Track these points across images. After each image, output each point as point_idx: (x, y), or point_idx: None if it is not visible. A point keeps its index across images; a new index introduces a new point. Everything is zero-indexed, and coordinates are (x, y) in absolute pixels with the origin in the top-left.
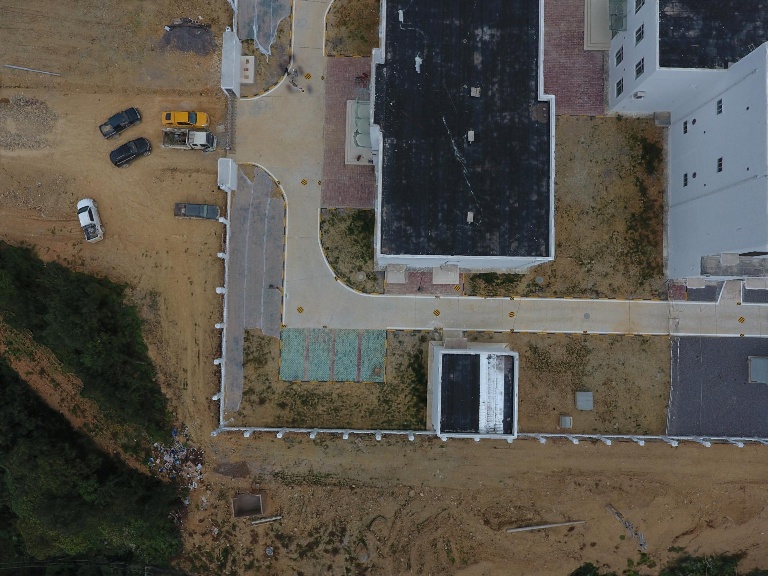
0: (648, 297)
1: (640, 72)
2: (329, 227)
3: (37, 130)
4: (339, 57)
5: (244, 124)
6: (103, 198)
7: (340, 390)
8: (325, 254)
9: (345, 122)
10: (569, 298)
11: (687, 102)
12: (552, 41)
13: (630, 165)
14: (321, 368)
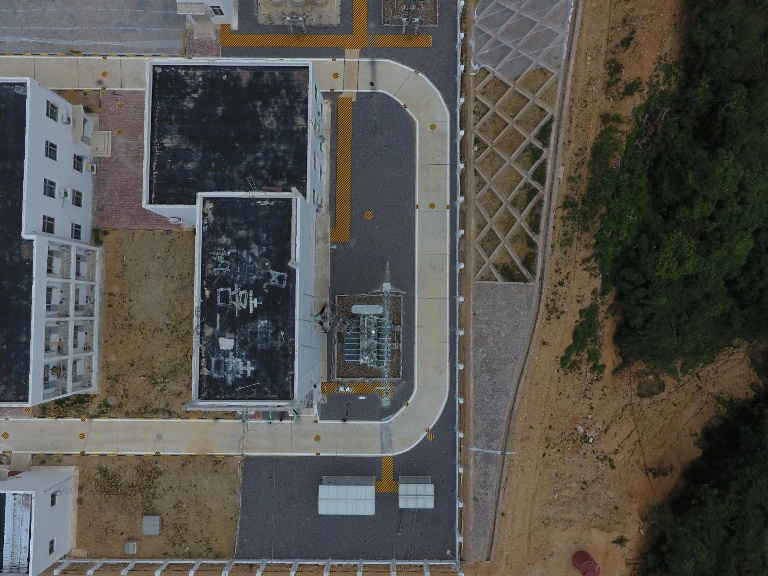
0: (222, 416)
1: None
2: None
3: None
4: None
5: None
6: None
7: None
8: None
9: None
10: (141, 418)
11: None
12: (129, 153)
13: None
14: None
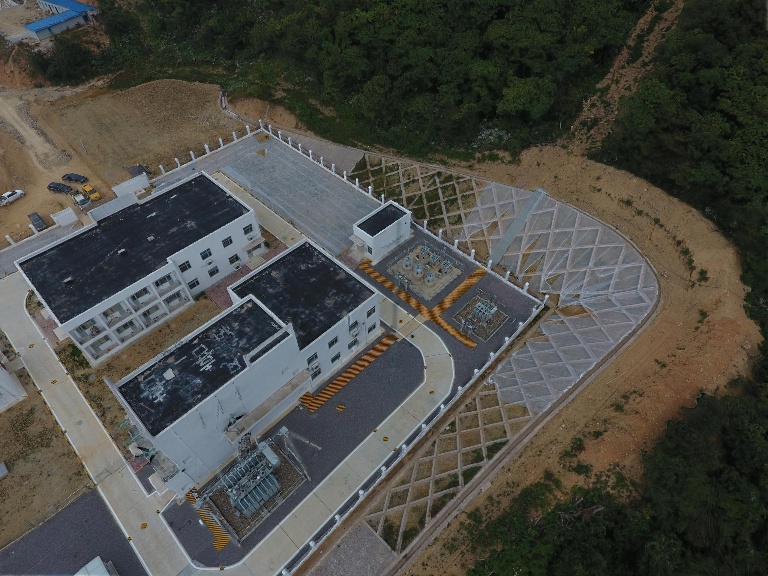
0: (121, 446)
1: None
2: None
3: (55, 164)
4: None
5: None
6: (29, 196)
7: None
8: None
9: None
10: (88, 402)
11: None
12: None
13: None
14: None
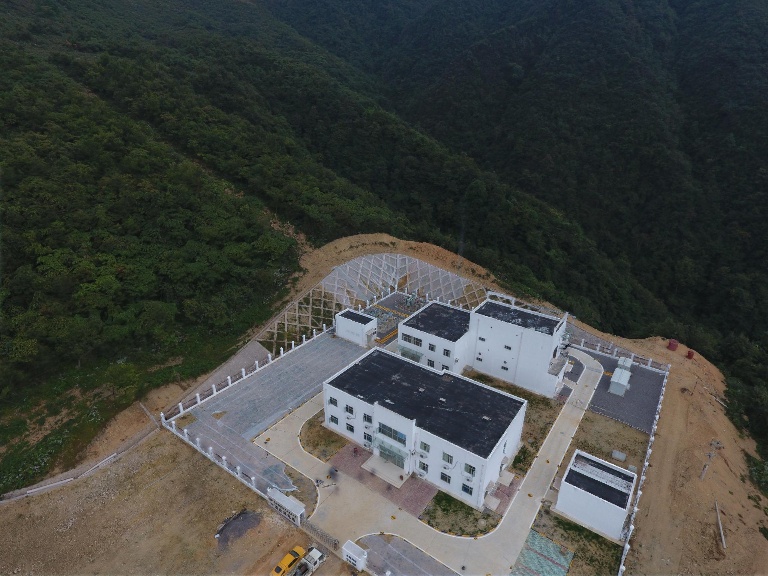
0: (560, 408)
1: (448, 354)
2: (435, 521)
3: None
4: (332, 457)
5: (325, 529)
6: None
7: None
8: (453, 534)
9: (373, 475)
10: (547, 435)
11: (468, 354)
12: None
13: None
14: None
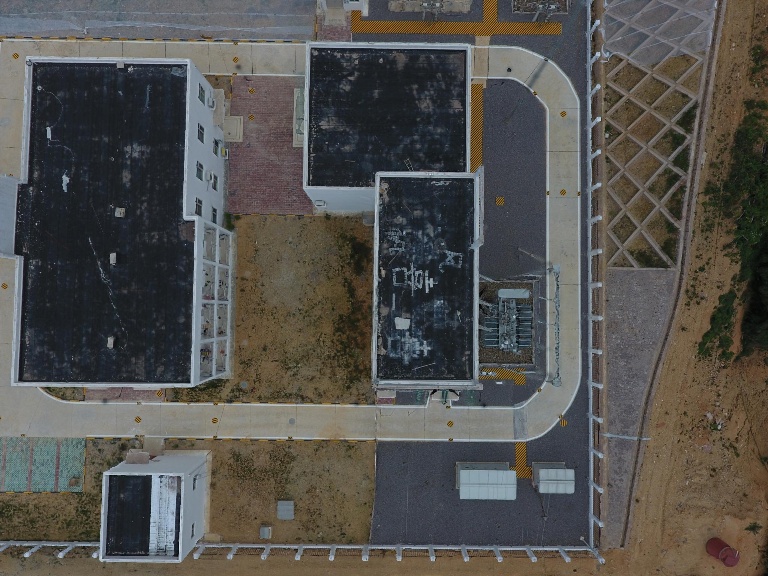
0: (355, 401)
1: None
2: None
3: None
4: None
5: None
6: None
7: (37, 501)
8: None
9: None
10: (274, 403)
11: None
12: (261, 138)
13: (338, 265)
14: (18, 478)
